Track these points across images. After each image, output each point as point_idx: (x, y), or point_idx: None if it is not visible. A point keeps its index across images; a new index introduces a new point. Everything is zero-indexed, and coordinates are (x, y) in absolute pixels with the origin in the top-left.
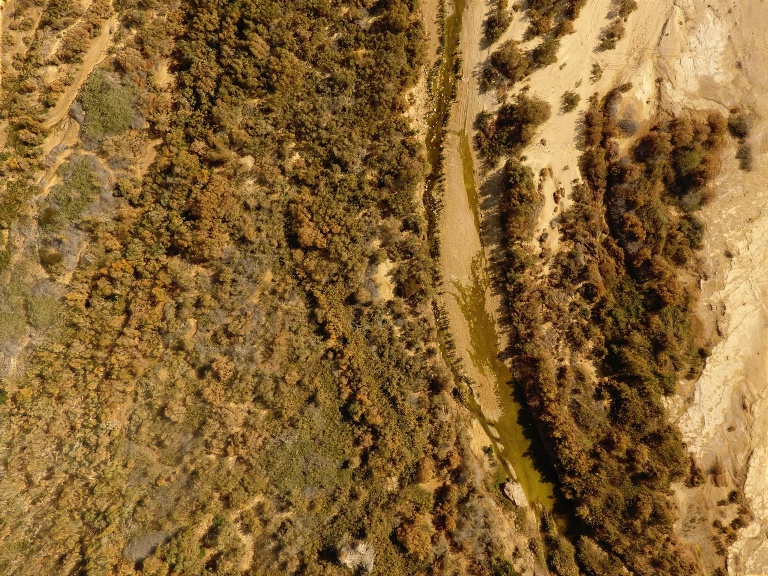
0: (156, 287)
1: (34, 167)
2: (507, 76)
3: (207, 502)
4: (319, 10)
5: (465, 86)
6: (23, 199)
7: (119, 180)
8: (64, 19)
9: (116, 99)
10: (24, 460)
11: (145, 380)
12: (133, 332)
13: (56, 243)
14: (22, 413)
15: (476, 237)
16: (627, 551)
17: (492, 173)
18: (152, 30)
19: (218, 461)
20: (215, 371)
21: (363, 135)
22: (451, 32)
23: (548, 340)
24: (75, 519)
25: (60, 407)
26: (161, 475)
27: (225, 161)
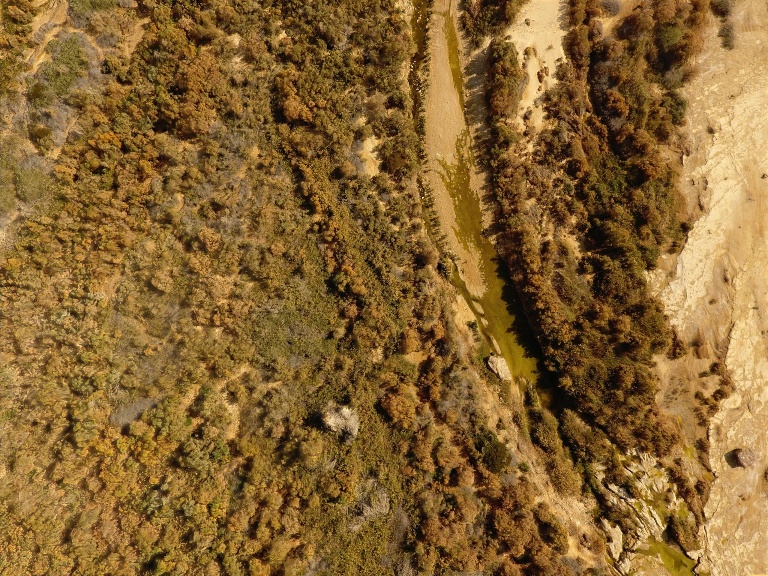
0: (143, 160)
1: (23, 45)
2: None
3: (193, 370)
4: None
5: None
6: (12, 75)
7: (107, 55)
8: None
9: None
10: (12, 330)
11: (132, 252)
12: (120, 203)
13: (45, 118)
14: (10, 283)
15: (461, 116)
16: (610, 422)
17: (477, 53)
18: None
19: (205, 332)
20: (202, 242)
21: (349, 12)
22: None
23: (532, 215)
24: (62, 386)
25: (48, 279)
26: (148, 345)
27: (212, 37)
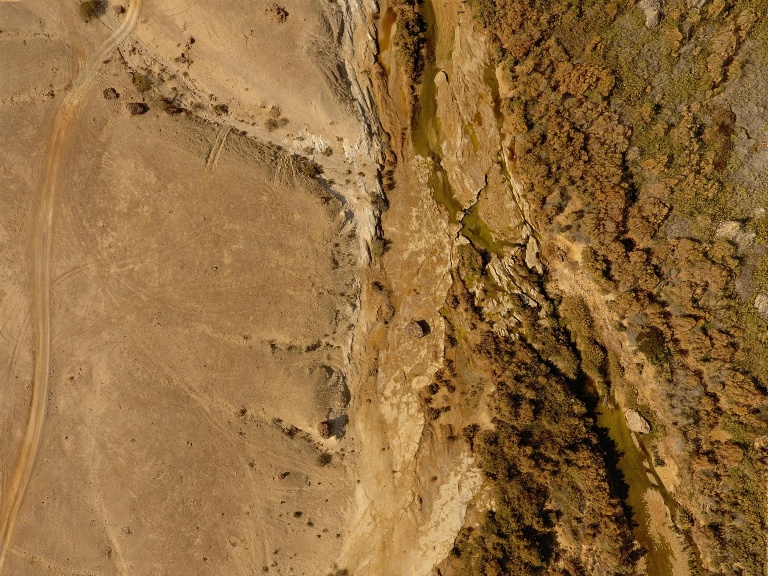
0: None
1: None
2: None
3: None
4: None
5: None
6: None
7: None
8: None
9: None
10: None
11: None
12: None
13: None
14: None
15: None
16: None
17: None
18: None
19: None
20: None
21: None
22: None
23: (603, 571)
24: None
25: None
26: None
27: None
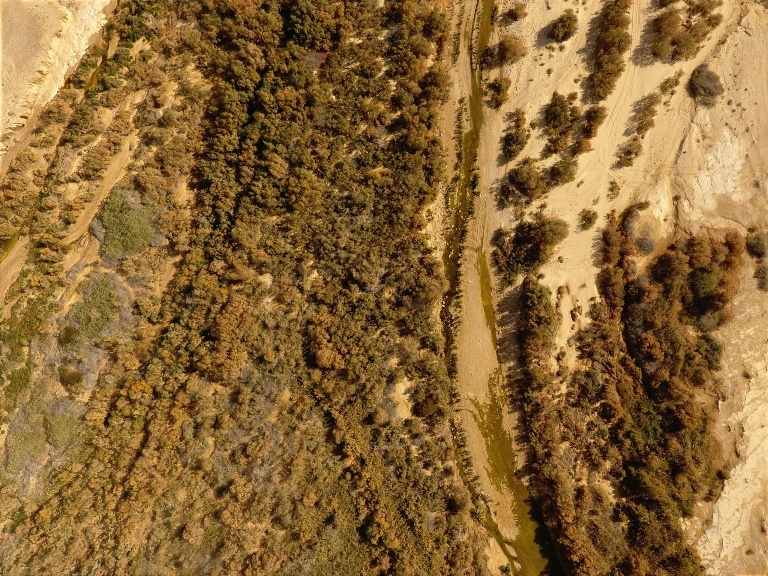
0: (175, 408)
1: (54, 284)
2: (525, 194)
3: None
4: (338, 130)
5: (482, 203)
6: (43, 317)
7: (139, 299)
8: (85, 137)
9: (136, 219)
10: None
11: (163, 500)
12: (152, 453)
13: (76, 362)
14: (41, 534)
15: (493, 354)
16: None
17: (509, 290)
18: (172, 150)
19: None
20: (233, 492)
21: (381, 255)
22: (469, 148)
23: (566, 460)
24: None
25: (79, 526)
26: None
27: (244, 280)
